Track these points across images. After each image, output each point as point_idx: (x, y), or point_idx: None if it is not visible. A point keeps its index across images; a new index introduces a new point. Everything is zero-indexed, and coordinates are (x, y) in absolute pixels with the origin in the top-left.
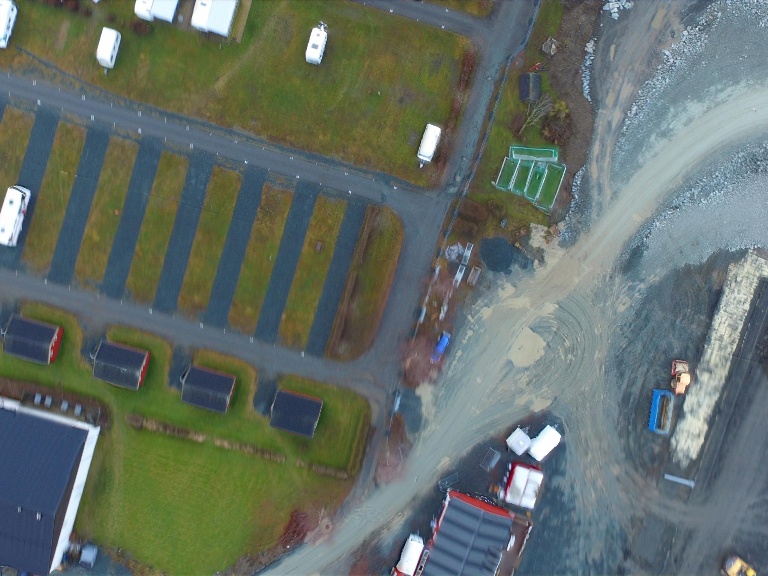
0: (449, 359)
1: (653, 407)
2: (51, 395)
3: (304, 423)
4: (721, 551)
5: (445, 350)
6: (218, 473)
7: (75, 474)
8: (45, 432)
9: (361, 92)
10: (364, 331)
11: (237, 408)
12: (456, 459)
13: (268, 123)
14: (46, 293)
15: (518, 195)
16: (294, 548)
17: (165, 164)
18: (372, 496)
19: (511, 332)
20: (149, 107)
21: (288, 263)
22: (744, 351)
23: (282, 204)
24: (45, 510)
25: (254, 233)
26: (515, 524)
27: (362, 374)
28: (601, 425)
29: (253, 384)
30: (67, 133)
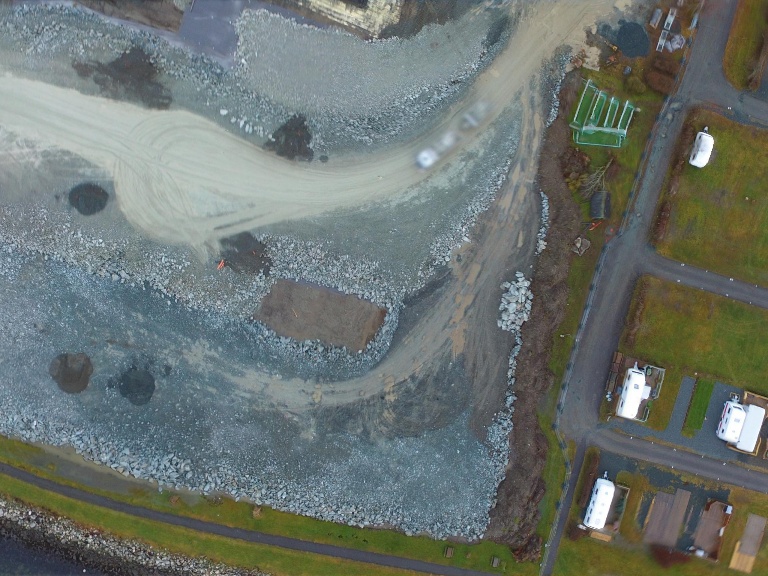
0: None
1: None
2: None
3: None
4: None
5: None
6: None
7: None
8: None
9: (761, 202)
10: None
11: None
12: None
13: None
14: None
15: None
16: None
17: None
18: None
19: None
20: None
21: None
22: None
23: None
24: None
25: None
26: None
27: None
28: None
29: None
30: None
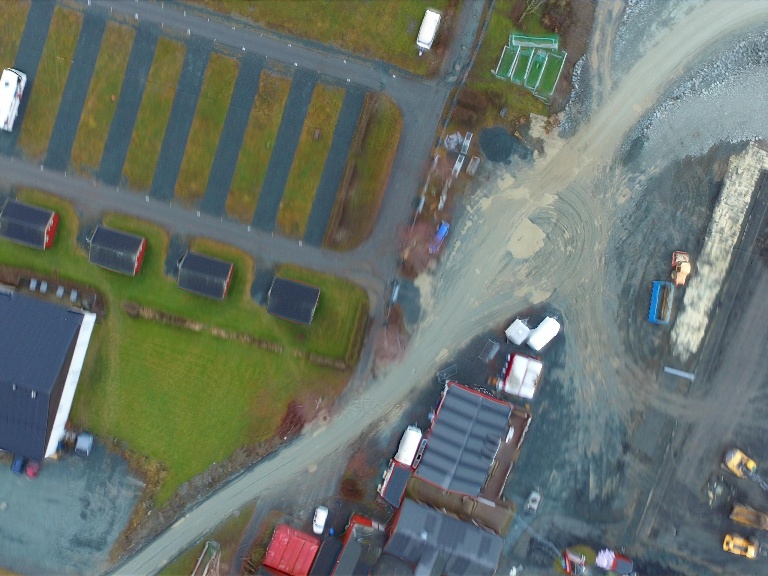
0: (448, 250)
1: (653, 299)
2: (47, 281)
3: (301, 309)
4: (721, 445)
5: (444, 240)
6: (215, 363)
7: (70, 357)
8: (40, 316)
9: None
10: (362, 221)
11: (234, 297)
12: (455, 351)
13: (266, 9)
14: (42, 179)
15: (518, 84)
16: (291, 439)
17: (162, 50)
18: (370, 388)
19: (510, 223)
20: None
21: (286, 151)
22: (745, 243)
23: (280, 92)
24: (40, 388)
25: (252, 121)
26: (514, 416)
27: (360, 264)
28: (601, 317)
29: (250, 273)
30: (63, 18)
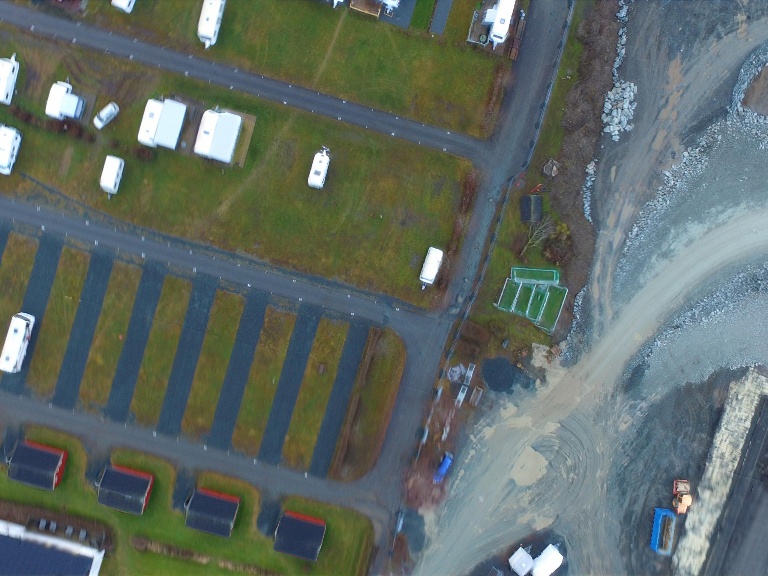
0: (452, 479)
1: (655, 526)
2: (56, 520)
3: (308, 548)
4: None
5: (448, 470)
6: None
7: None
8: (50, 559)
9: (363, 215)
10: (367, 452)
11: (241, 529)
12: None
13: (271, 246)
14: (50, 417)
15: (520, 315)
16: None
17: (168, 288)
18: None
19: (513, 451)
20: (152, 232)
21: (291, 385)
22: (745, 469)
23: (285, 327)
24: None
25: (257, 356)
26: None
27: (365, 494)
28: (603, 543)
29: (257, 505)
30: (71, 258)
